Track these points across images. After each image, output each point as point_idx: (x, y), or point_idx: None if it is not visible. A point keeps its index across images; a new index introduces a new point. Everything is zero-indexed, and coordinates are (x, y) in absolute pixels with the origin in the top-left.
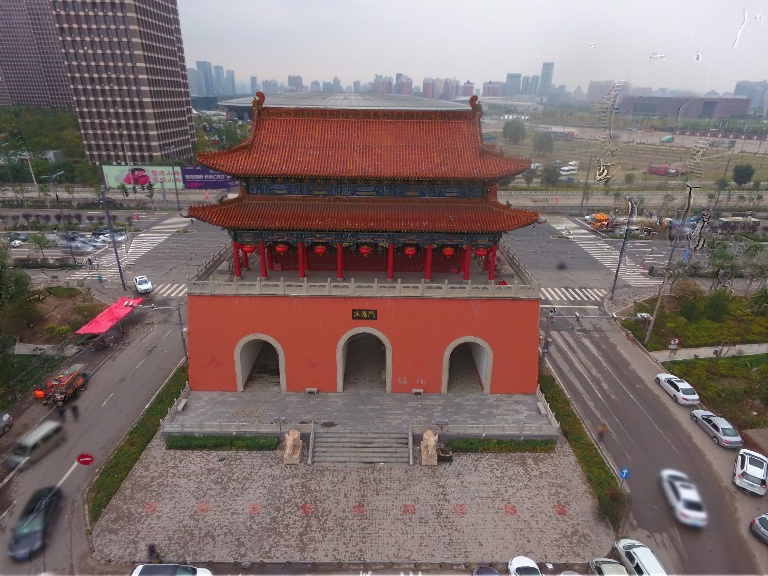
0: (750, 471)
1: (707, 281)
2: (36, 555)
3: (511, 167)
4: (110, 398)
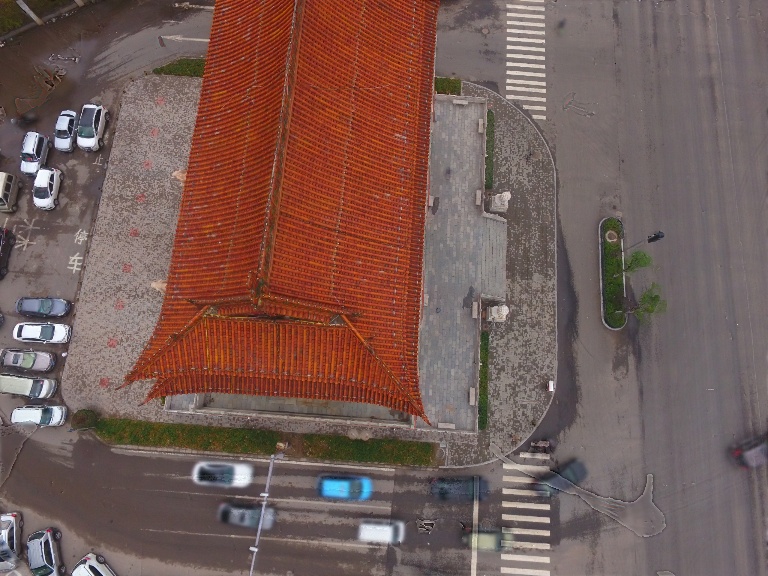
0: (81, 568)
1: None
2: (137, 53)
3: (152, 350)
4: None
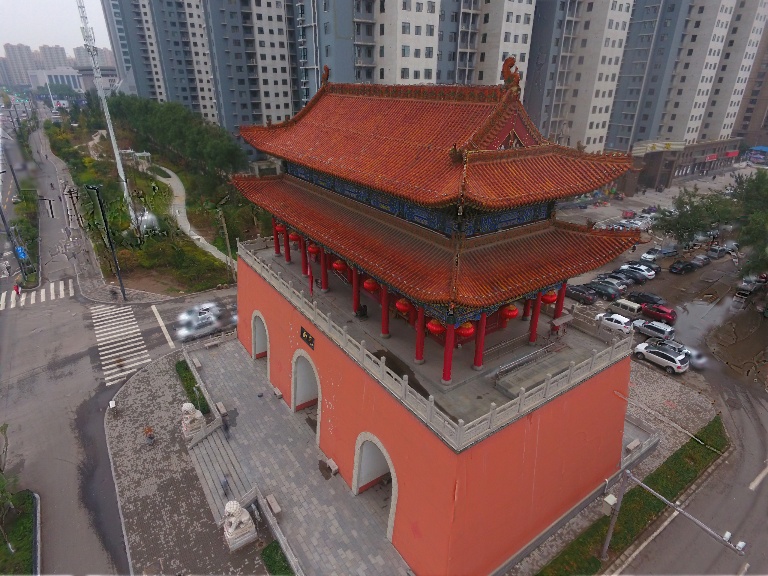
0: None
1: (124, 244)
2: (759, 425)
3: None
4: (739, 574)
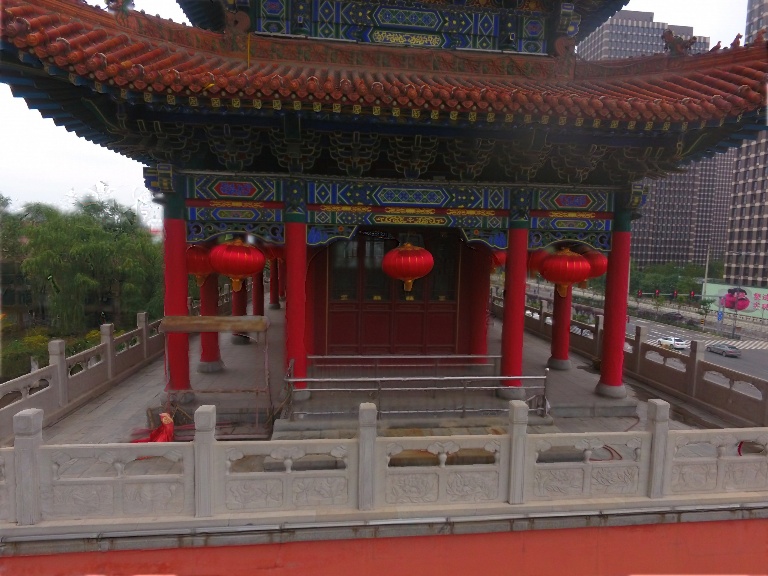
0: None
1: None
2: None
3: None
4: None
